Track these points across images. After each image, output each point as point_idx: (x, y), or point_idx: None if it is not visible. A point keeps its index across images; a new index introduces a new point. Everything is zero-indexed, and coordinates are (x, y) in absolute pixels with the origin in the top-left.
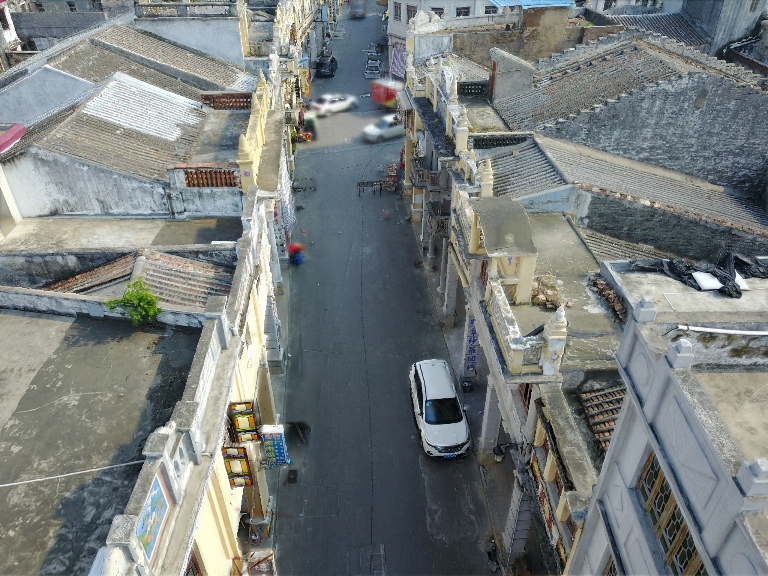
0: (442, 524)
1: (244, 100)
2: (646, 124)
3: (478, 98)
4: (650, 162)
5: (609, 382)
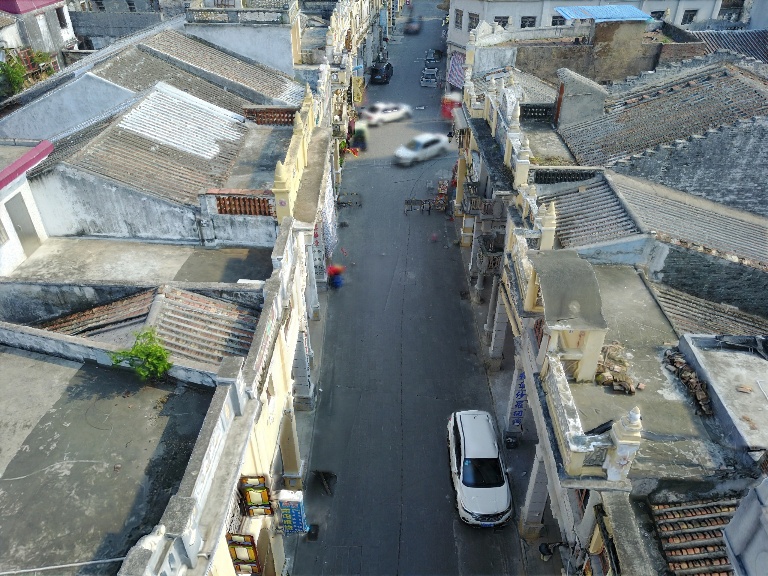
0: None
1: (289, 116)
2: (736, 164)
3: (541, 122)
4: (737, 206)
5: (688, 495)
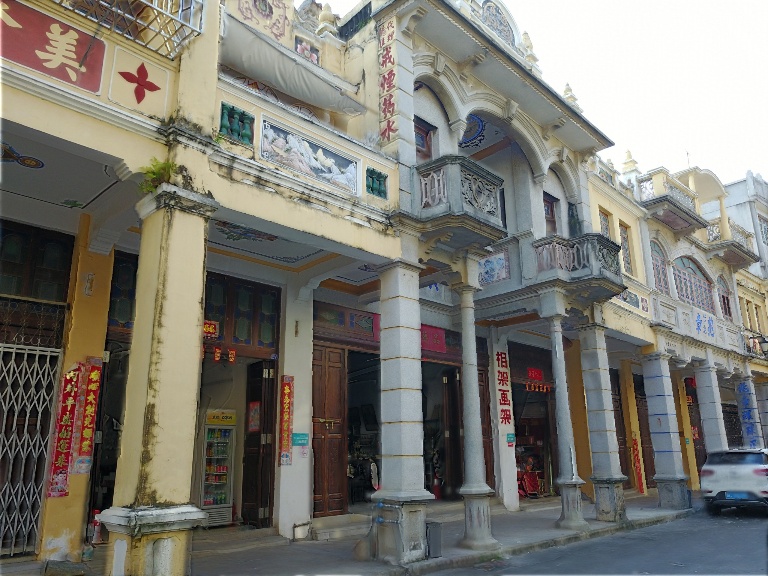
0: None
1: None
2: None
3: None
4: None
5: None
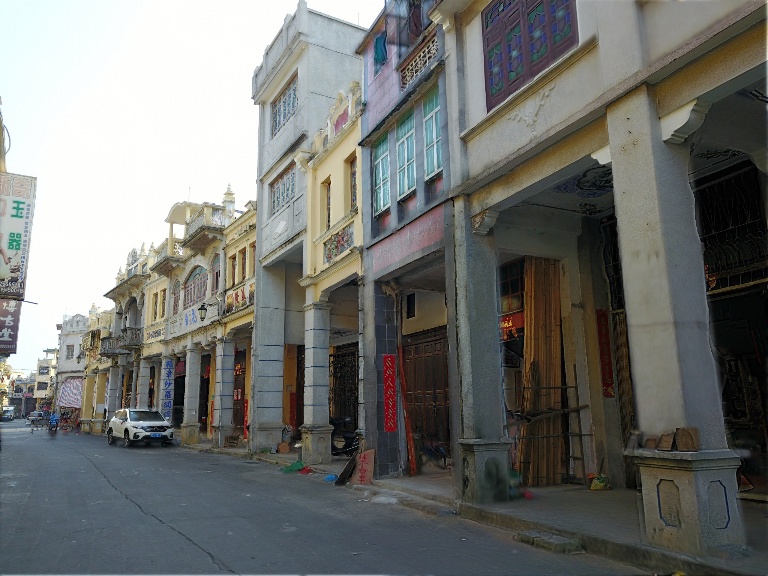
0: None
1: None
2: None
3: None
4: None
5: None
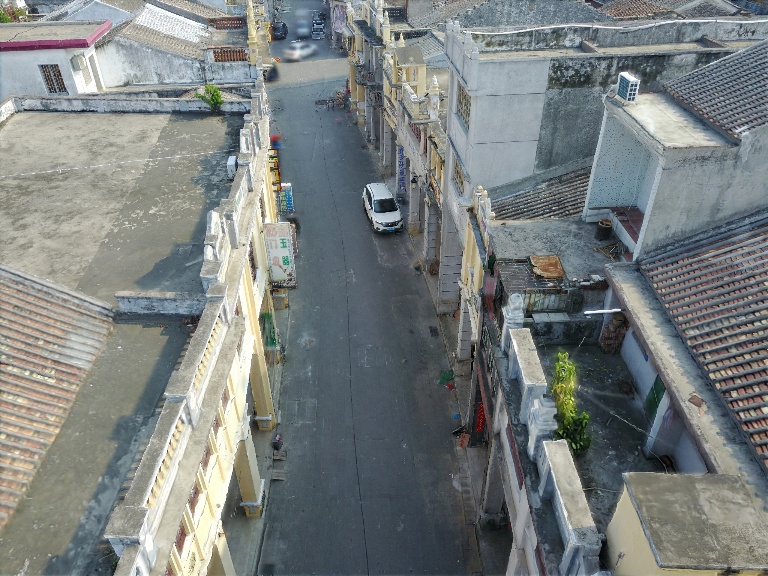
0: (388, 260)
1: (237, 22)
2: (501, 22)
3: (398, 19)
4: None
5: None
